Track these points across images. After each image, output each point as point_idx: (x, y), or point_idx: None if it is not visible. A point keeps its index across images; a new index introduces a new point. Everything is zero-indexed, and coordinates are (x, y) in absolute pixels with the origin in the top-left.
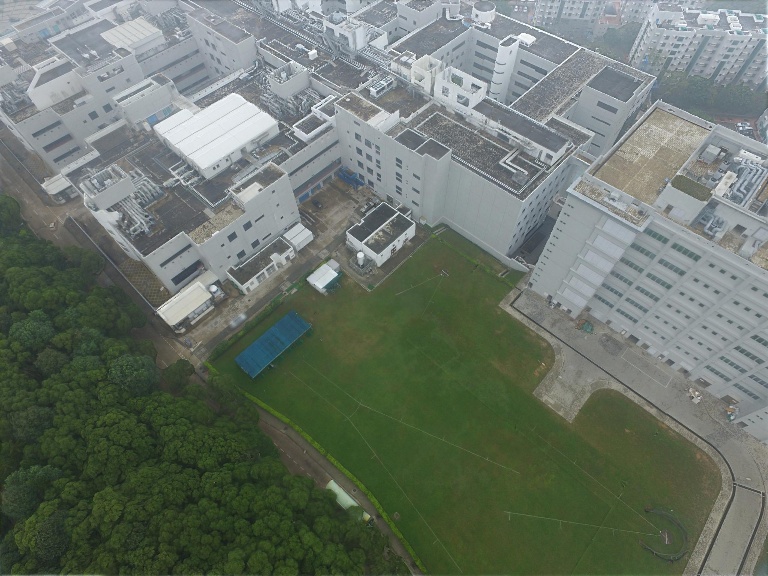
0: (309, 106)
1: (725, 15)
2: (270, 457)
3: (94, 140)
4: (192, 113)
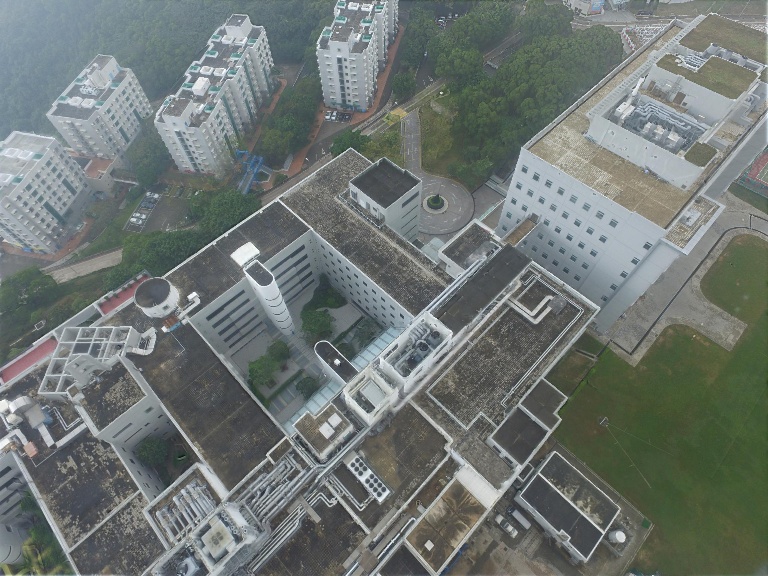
0: None
1: (195, 73)
2: None
3: None
4: None
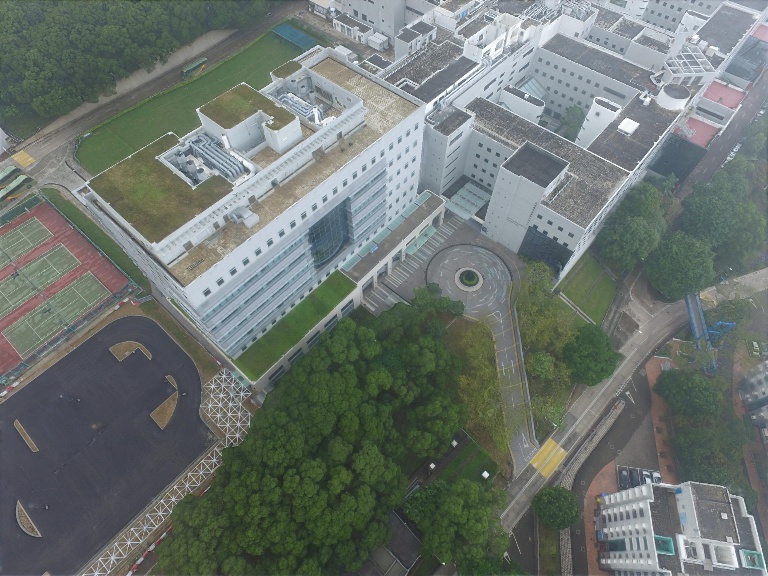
0: None
1: None
2: (203, 6)
3: None
4: None
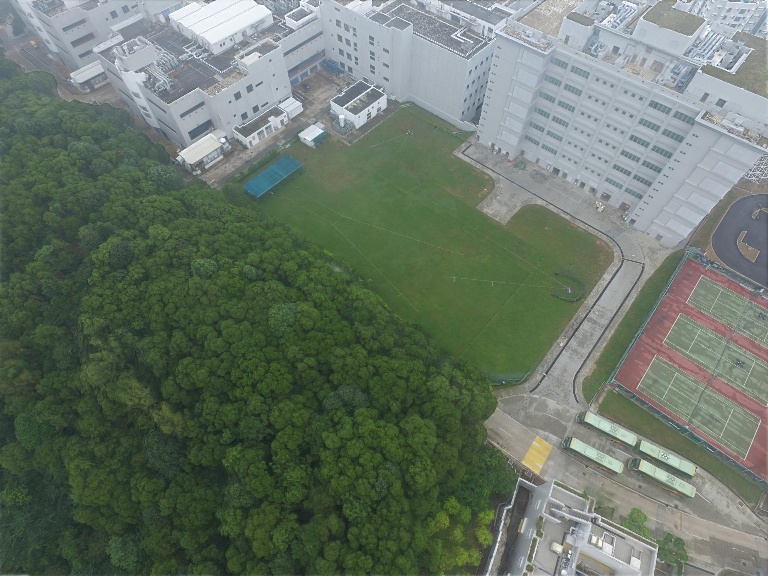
0: (298, 4)
1: None
2: None
3: (118, 29)
4: (200, 6)
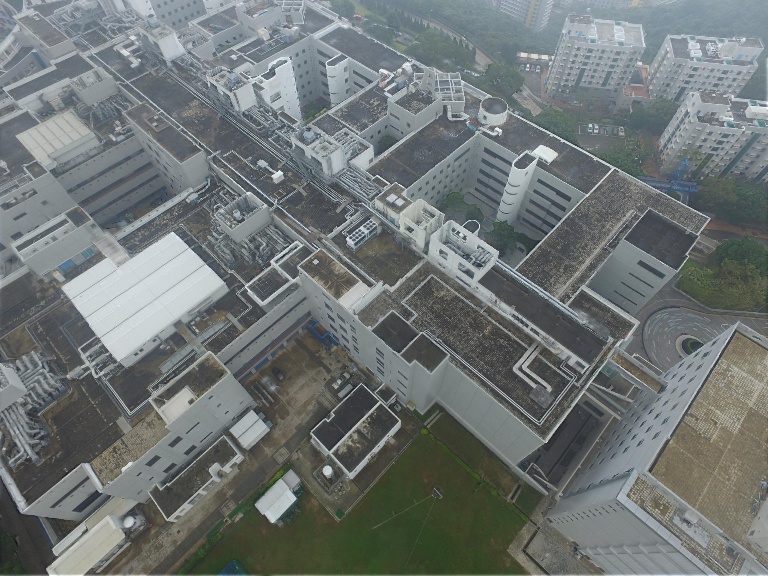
0: (270, 250)
1: None
2: None
3: None
4: (116, 265)
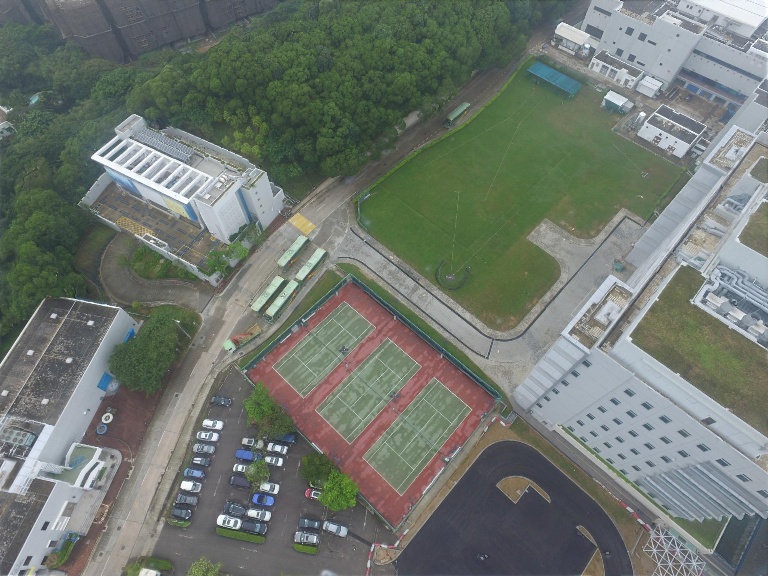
0: None
1: None
2: None
3: None
4: None
